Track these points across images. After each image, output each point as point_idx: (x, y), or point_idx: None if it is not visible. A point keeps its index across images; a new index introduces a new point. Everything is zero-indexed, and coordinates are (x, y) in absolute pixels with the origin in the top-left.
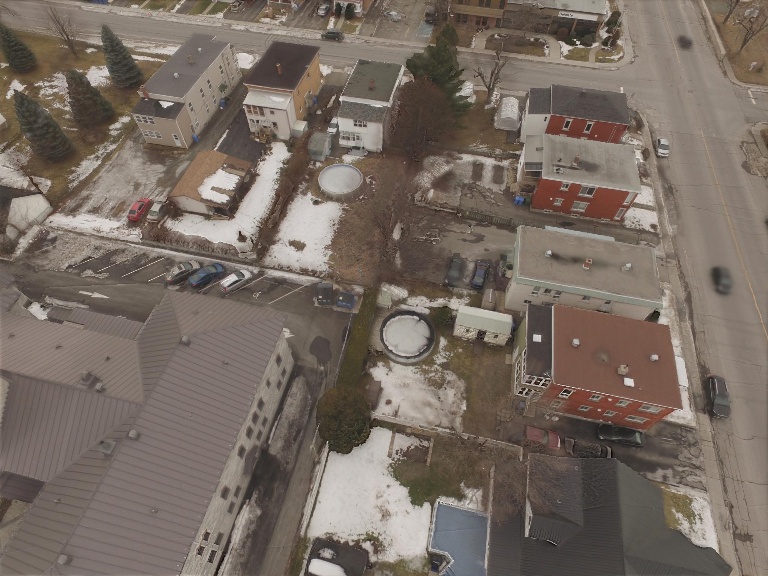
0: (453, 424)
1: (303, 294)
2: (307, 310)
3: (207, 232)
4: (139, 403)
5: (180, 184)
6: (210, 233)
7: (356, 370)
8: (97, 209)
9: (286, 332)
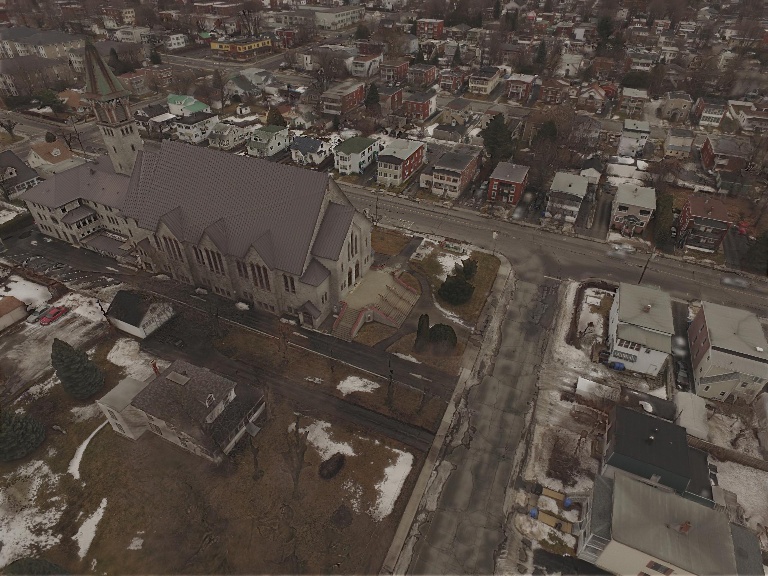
0: (5, 211)
1: (7, 254)
2: (14, 248)
3: (25, 297)
4: None
5: (8, 308)
6: (23, 296)
7: (18, 217)
8: (83, 324)
9: (33, 242)
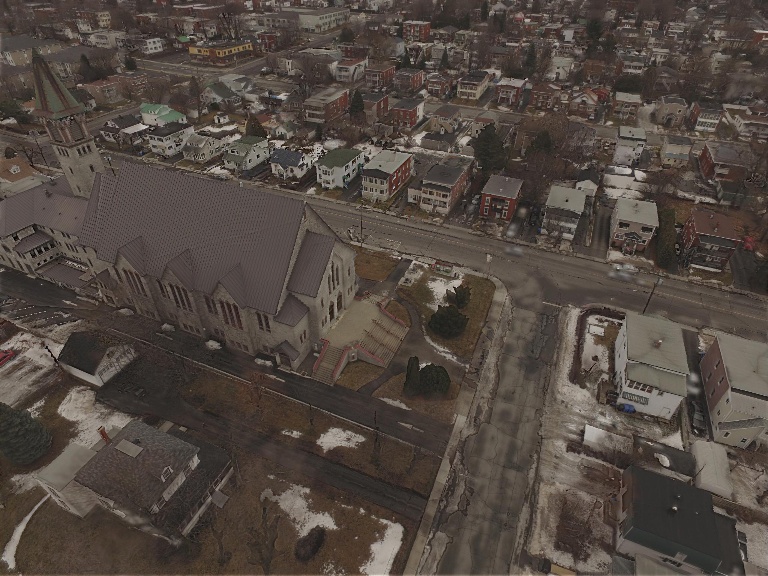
0: None
1: None
2: None
3: None
4: (36, 187)
5: None
6: None
7: None
8: (34, 370)
9: None
